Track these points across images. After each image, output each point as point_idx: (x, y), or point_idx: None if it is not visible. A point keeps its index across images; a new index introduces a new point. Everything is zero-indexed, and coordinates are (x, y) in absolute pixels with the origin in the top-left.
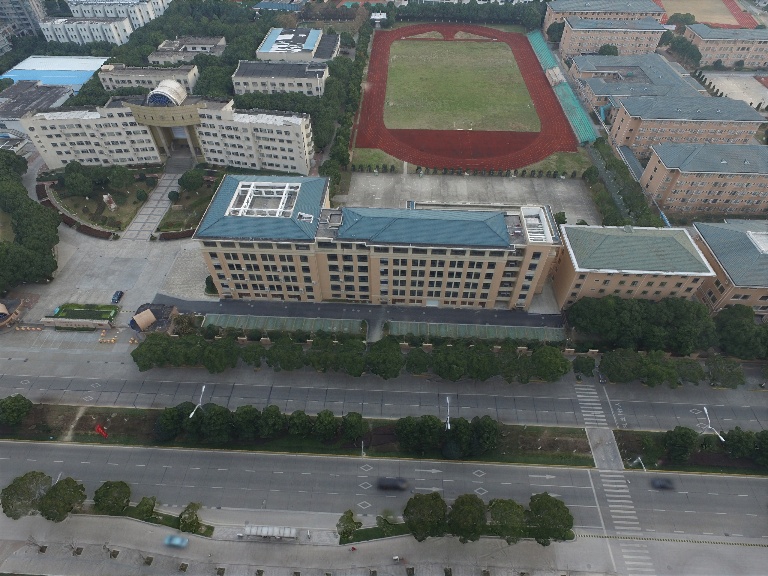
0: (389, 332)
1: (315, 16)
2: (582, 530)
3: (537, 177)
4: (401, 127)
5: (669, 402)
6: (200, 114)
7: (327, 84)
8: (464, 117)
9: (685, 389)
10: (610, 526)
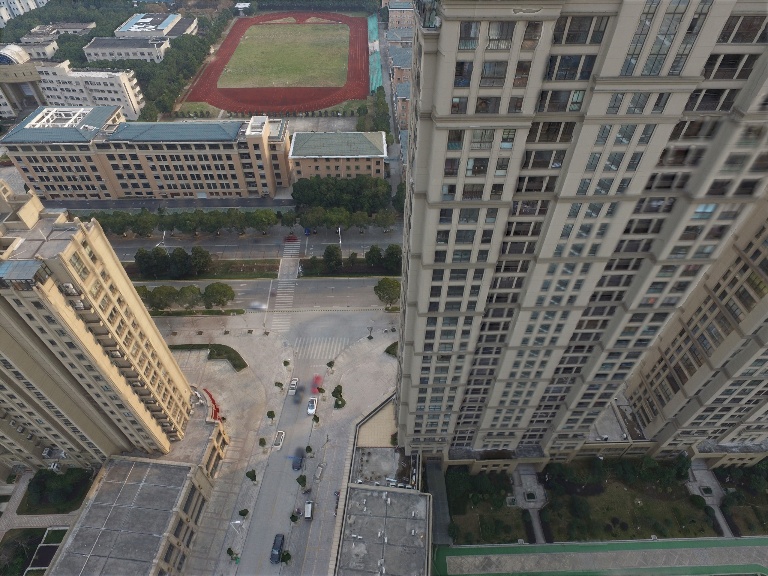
0: (162, 214)
1: (189, 7)
2: (251, 309)
3: (324, 116)
4: (230, 86)
5: (349, 243)
6: (39, 71)
7: (166, 53)
8: (285, 78)
9: (365, 235)
10: (272, 306)
